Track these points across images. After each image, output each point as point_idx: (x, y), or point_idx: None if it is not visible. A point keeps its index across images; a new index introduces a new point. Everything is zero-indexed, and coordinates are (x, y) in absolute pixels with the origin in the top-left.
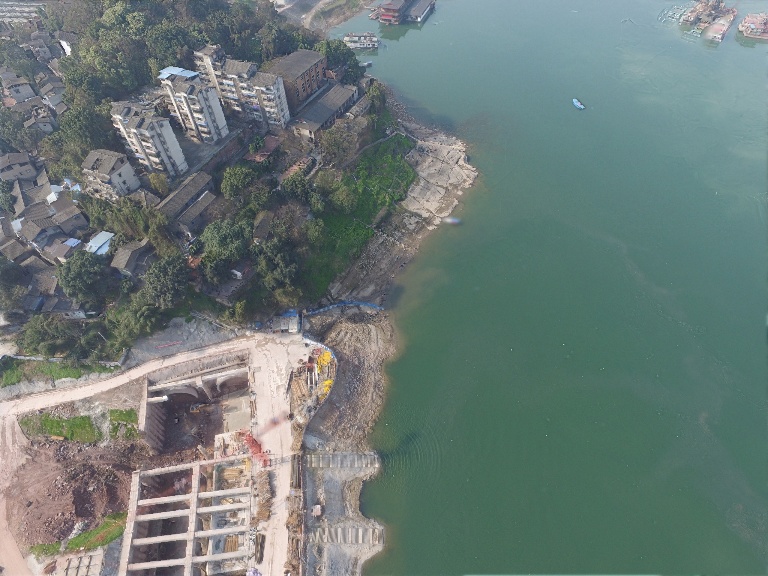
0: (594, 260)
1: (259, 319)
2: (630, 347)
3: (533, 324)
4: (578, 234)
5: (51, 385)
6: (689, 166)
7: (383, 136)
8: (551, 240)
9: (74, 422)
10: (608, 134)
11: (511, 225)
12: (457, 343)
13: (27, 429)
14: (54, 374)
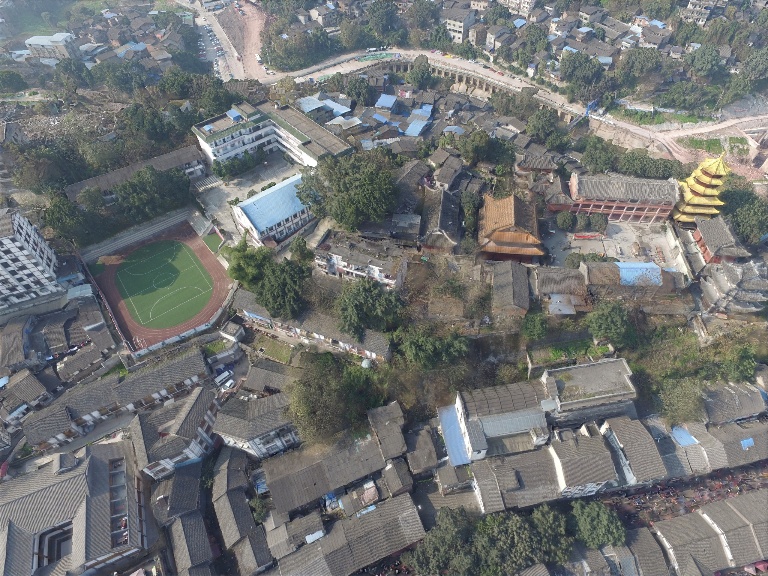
0: None
1: None
2: None
3: None
4: None
5: (681, 126)
6: None
7: None
8: None
9: (711, 142)
10: None
11: None
12: None
13: (683, 144)
14: (682, 120)
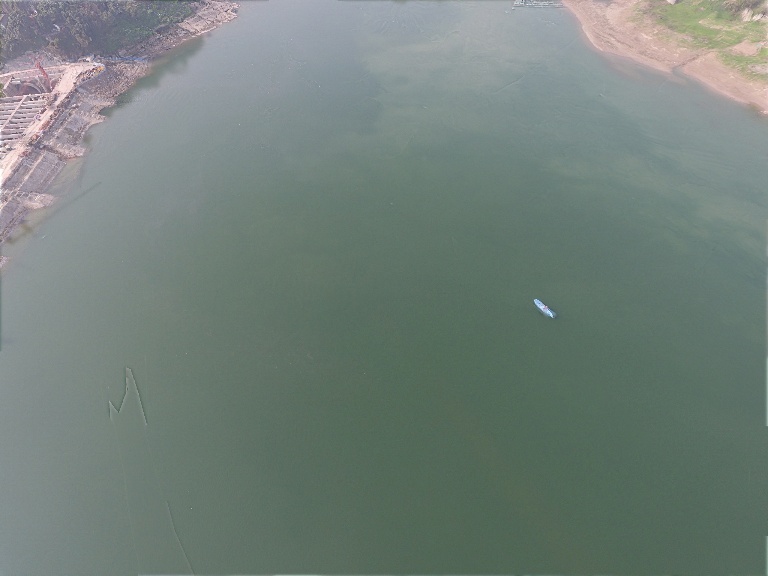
0: (273, 44)
1: (73, 57)
2: None
3: (222, 65)
4: (274, 36)
5: None
6: (360, 8)
7: None
8: (256, 38)
9: None
10: (333, 0)
11: (239, 34)
12: (178, 71)
13: None
14: None
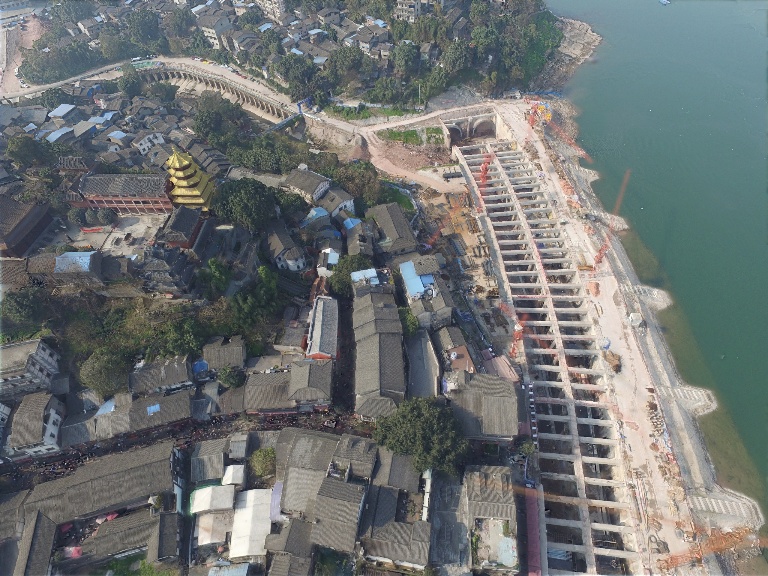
0: (694, 74)
1: (495, 92)
2: (726, 108)
3: (661, 101)
4: (681, 63)
5: (387, 119)
6: (754, 28)
7: (540, 10)
8: (663, 66)
9: (408, 133)
10: (690, 17)
11: (633, 61)
12: (615, 109)
13: (382, 137)
14: (388, 114)
